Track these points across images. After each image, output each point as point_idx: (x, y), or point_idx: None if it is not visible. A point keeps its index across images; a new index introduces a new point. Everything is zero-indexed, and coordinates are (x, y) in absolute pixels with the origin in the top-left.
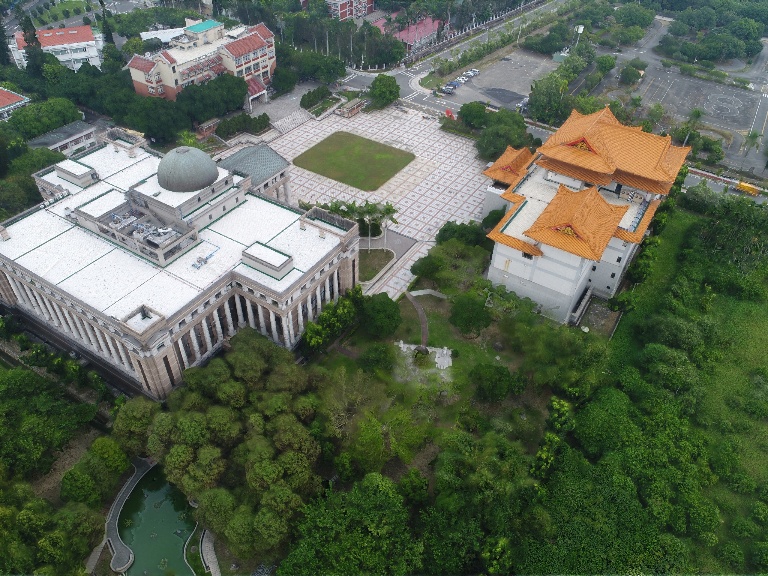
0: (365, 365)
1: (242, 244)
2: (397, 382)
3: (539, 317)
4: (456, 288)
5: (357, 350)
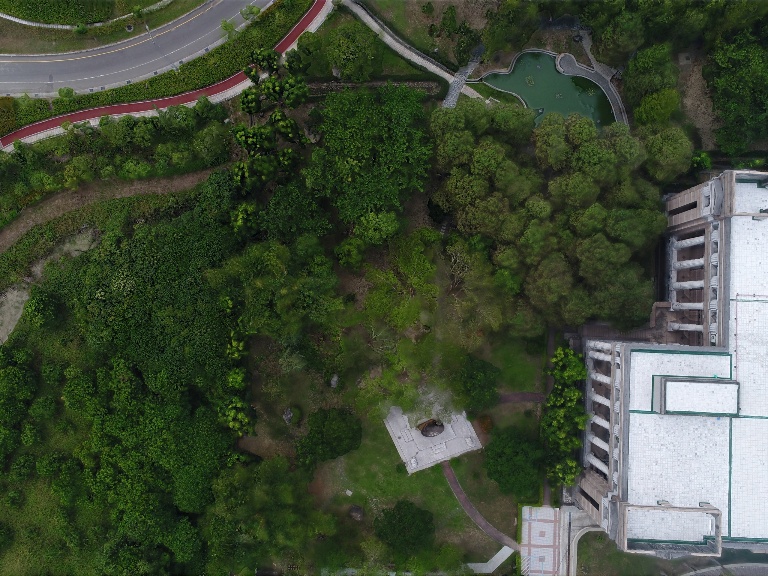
0: (486, 370)
1: (763, 417)
2: (432, 357)
3: (315, 573)
4: (448, 573)
5: (518, 408)
